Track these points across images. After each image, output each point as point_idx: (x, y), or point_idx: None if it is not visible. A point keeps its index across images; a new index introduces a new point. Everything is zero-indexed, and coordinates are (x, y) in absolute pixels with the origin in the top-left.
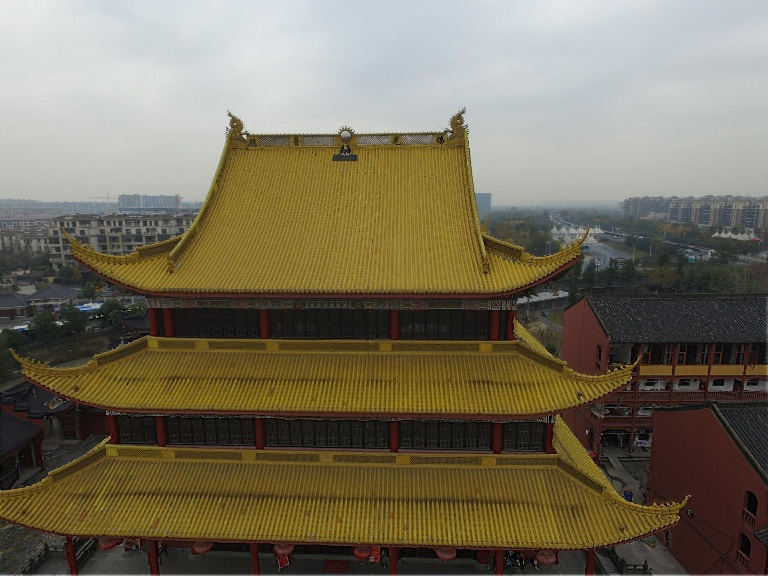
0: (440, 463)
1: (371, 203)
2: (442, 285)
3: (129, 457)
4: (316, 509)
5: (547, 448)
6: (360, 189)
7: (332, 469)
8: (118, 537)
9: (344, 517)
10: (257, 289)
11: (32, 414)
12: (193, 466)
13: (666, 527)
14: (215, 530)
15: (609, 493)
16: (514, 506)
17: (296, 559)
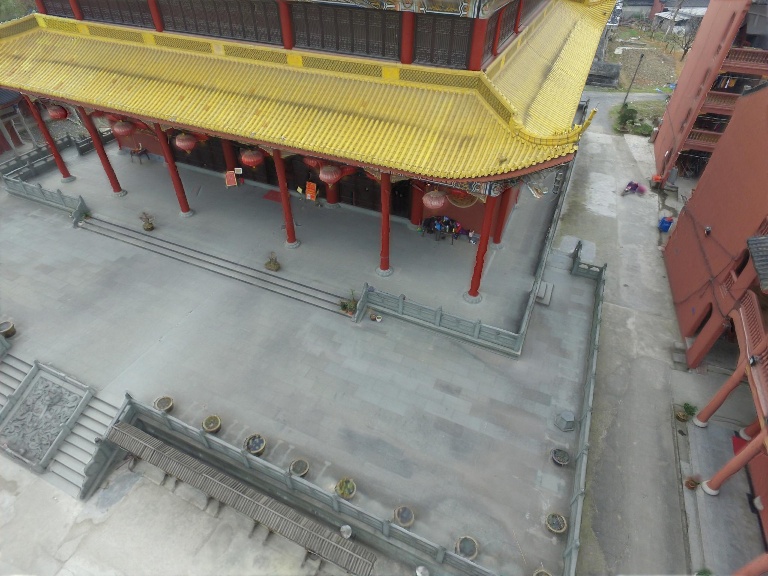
0: (335, 69)
1: None
2: None
3: (56, 30)
4: (190, 96)
5: (471, 63)
6: None
7: (223, 63)
8: (30, 92)
9: (212, 106)
10: None
11: None
12: (104, 45)
13: (555, 161)
14: (99, 98)
15: (514, 121)
16: (395, 125)
17: (246, 184)
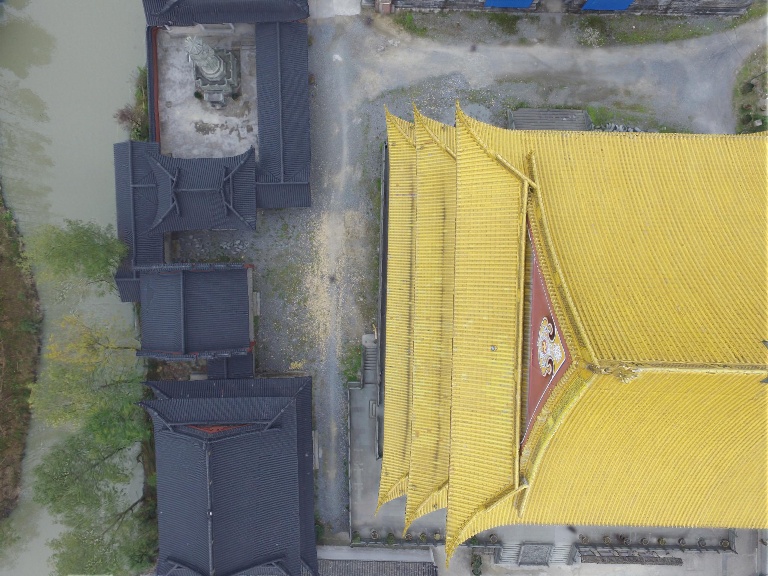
0: None
1: (765, 429)
2: (766, 520)
3: None
4: None
5: None
6: (766, 414)
7: None
8: None
9: None
10: (600, 522)
11: (233, 268)
12: None
13: None
14: None
15: None
16: None
17: None
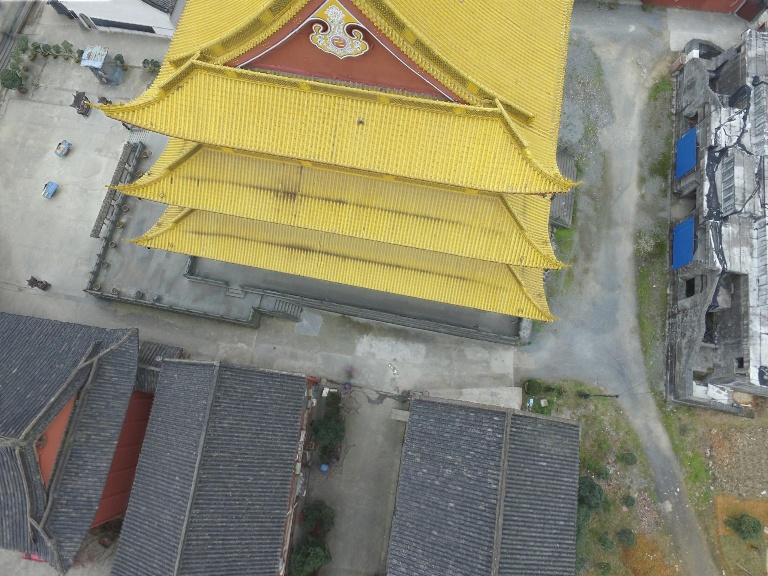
0: None
1: None
2: None
3: None
4: None
5: None
6: None
7: None
8: None
9: None
10: None
11: None
12: None
13: None
14: None
15: None
16: None
17: None
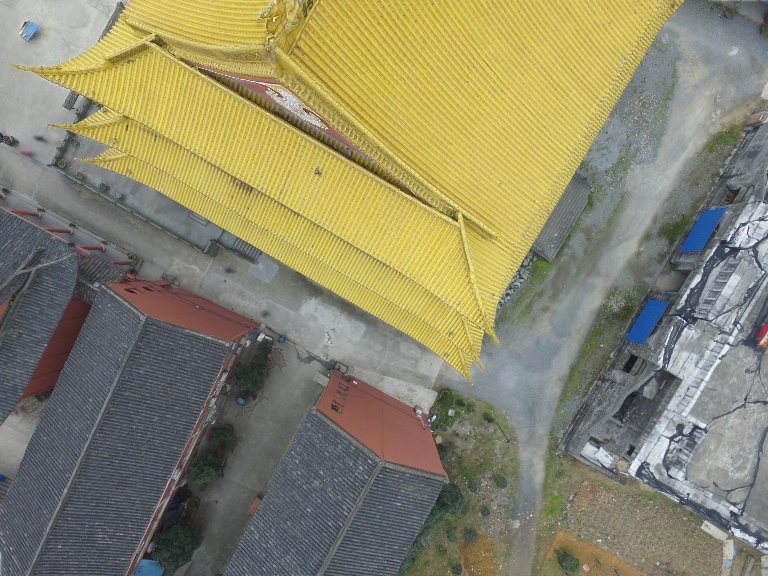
0: None
1: None
2: None
3: None
4: None
5: None
6: None
7: None
8: None
9: None
10: None
11: None
12: None
13: None
14: None
15: None
16: None
17: None
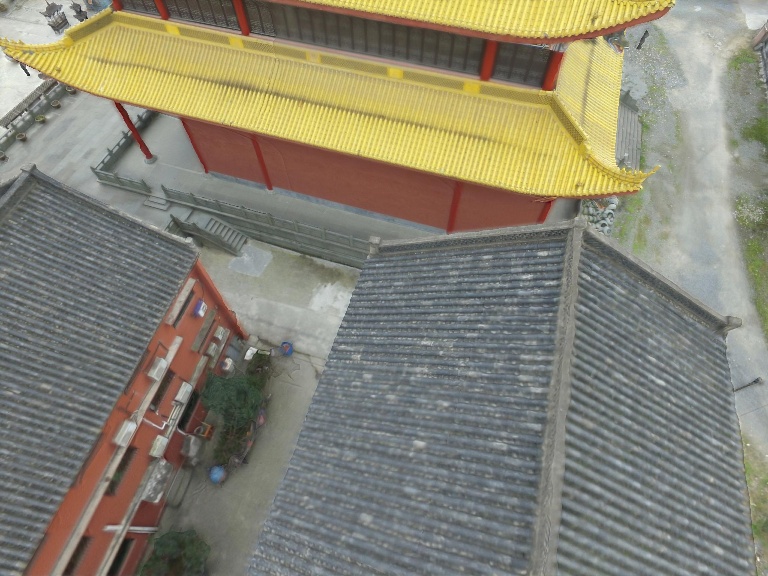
0: None
1: None
2: None
3: None
4: None
5: None
6: None
7: None
8: None
9: None
10: None
11: None
12: None
13: None
14: None
15: None
16: None
17: None
